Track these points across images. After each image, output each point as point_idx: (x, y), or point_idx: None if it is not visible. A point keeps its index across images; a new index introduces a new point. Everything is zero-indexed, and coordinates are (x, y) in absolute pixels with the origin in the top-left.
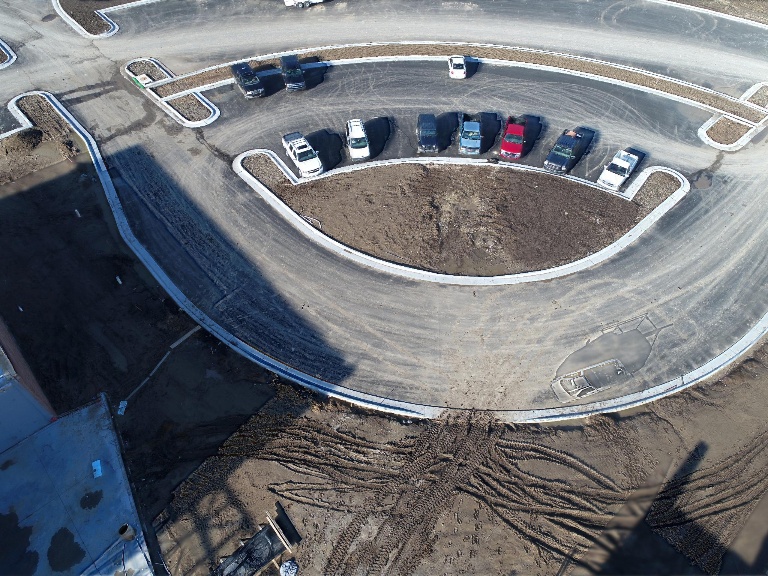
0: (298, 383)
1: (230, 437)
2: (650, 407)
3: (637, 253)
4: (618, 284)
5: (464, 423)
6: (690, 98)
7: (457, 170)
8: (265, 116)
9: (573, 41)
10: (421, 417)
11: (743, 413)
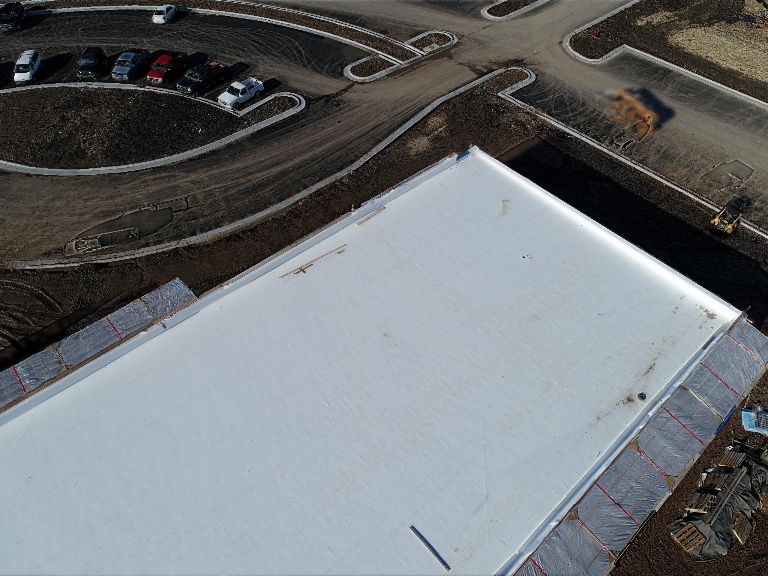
0: None
1: None
2: (137, 260)
3: (216, 155)
4: (181, 176)
5: None
6: (360, 42)
7: (106, 92)
8: None
9: None
10: None
11: (207, 263)
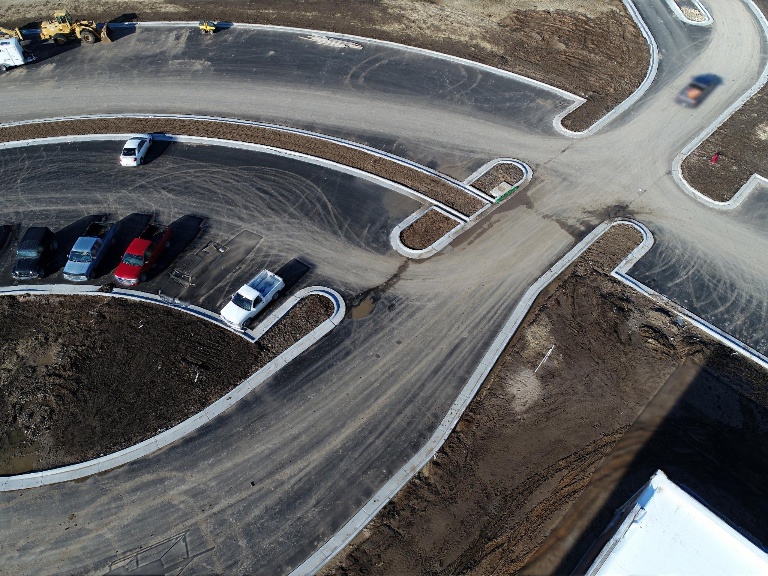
0: None
1: None
2: None
3: (225, 426)
4: (174, 481)
5: None
6: (404, 183)
7: (55, 303)
8: None
9: (300, 108)
10: None
11: None
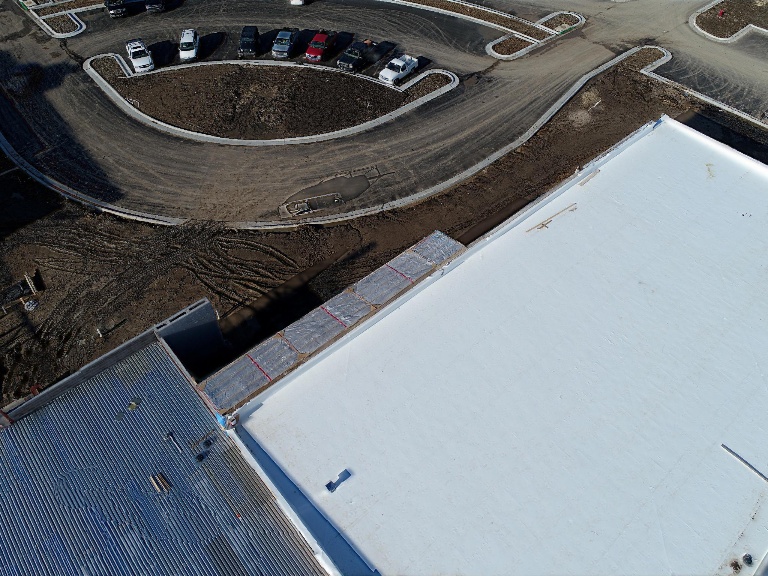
0: (82, 203)
1: (16, 232)
2: (349, 222)
3: (390, 127)
4: (364, 147)
5: (199, 228)
6: (493, 22)
7: (267, 69)
8: (123, 30)
9: None
10: (168, 224)
11: (417, 225)
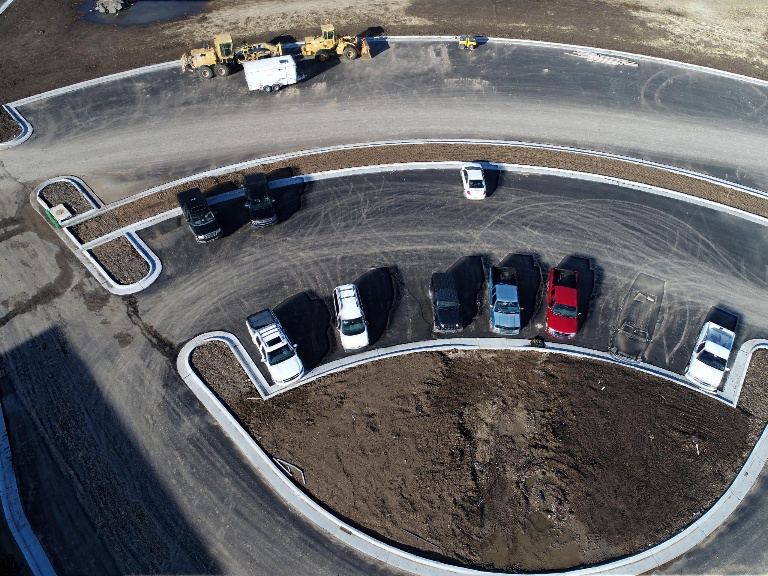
0: None
1: None
2: None
3: (762, 509)
4: None
5: None
6: None
7: (490, 360)
8: (223, 271)
9: (612, 133)
10: None
11: None
